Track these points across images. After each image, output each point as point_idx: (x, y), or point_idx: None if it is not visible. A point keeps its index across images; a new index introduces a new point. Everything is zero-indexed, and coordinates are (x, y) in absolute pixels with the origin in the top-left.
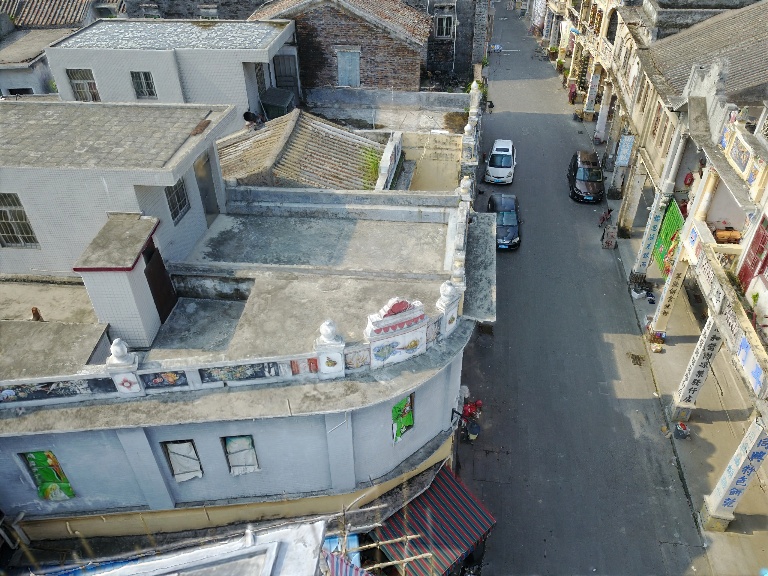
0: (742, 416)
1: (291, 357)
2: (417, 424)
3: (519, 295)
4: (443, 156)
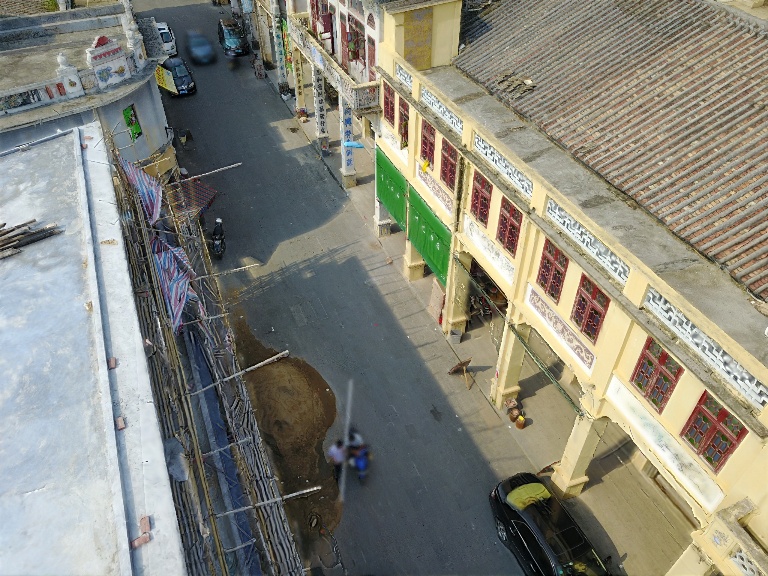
0: (358, 137)
1: (45, 82)
2: (144, 132)
3: (206, 118)
4: None
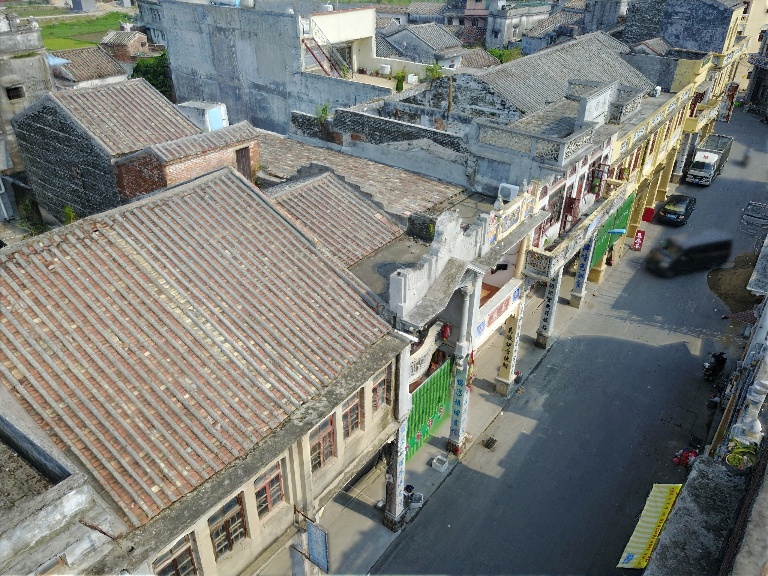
0: None
1: None
2: None
3: (566, 574)
4: None
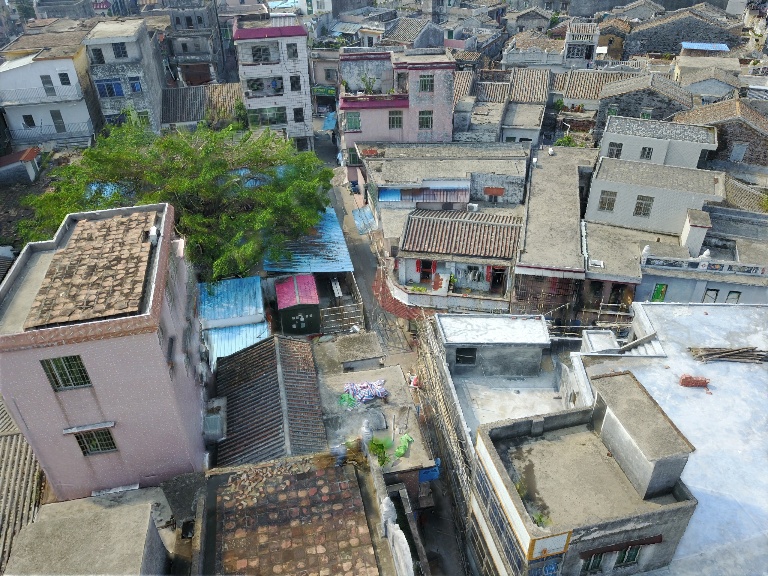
0: None
1: (765, 266)
2: None
3: None
4: None
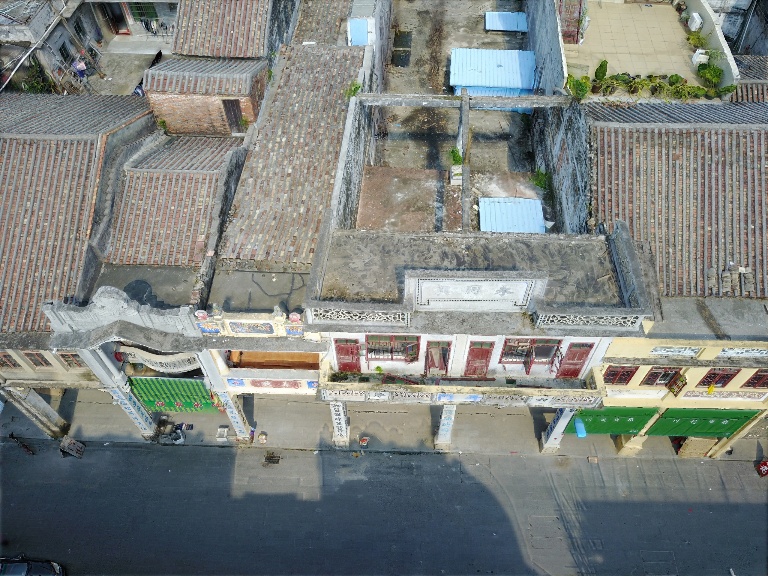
0: None
1: None
2: None
3: (160, 571)
4: None
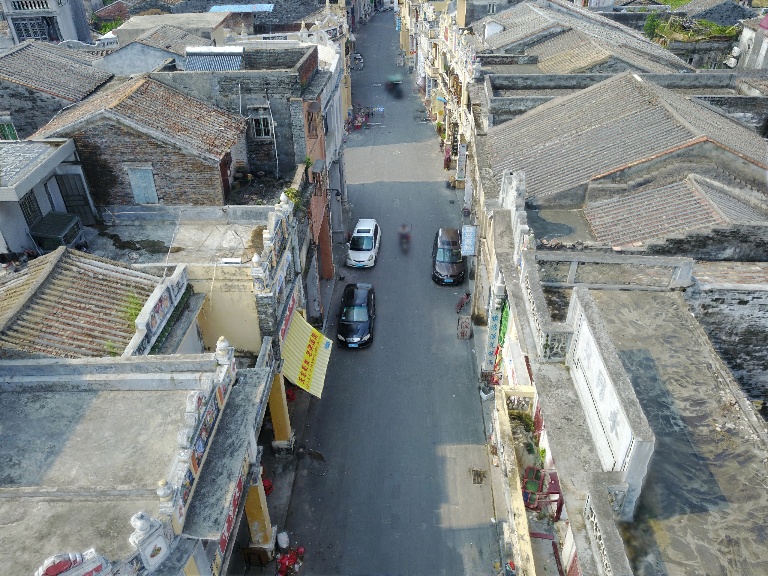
0: None
1: None
2: None
3: (364, 404)
4: (235, 287)
